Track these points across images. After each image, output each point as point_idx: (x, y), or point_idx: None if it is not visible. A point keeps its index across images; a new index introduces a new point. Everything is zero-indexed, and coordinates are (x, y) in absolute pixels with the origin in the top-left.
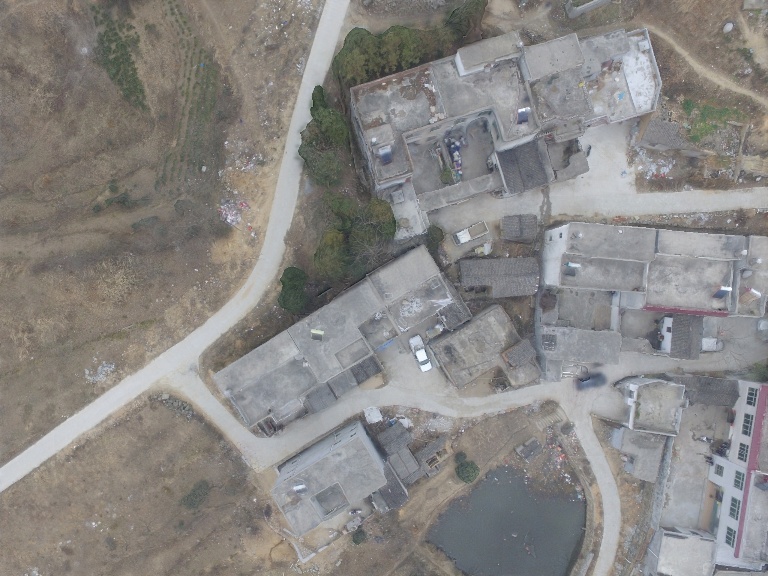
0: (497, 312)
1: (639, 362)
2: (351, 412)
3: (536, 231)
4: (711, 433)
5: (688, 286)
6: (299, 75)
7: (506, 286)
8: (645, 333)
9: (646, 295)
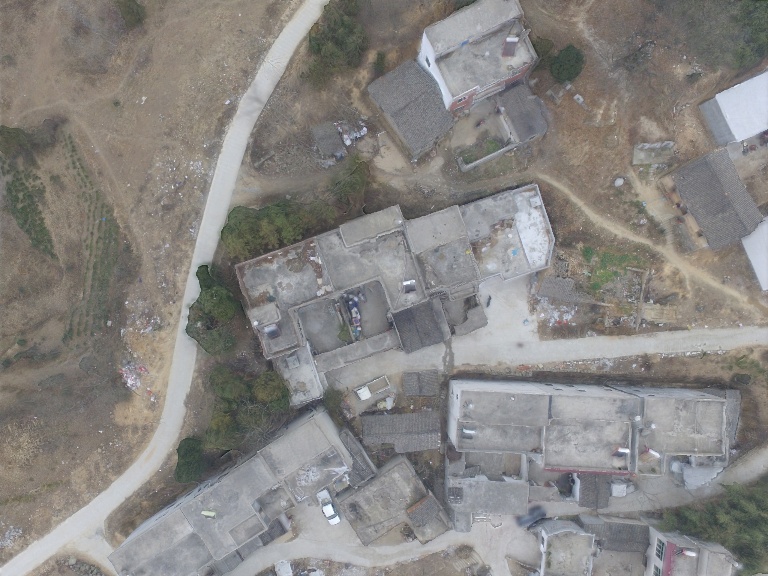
0: (401, 468)
1: (552, 504)
2: (262, 566)
3: (437, 386)
4: (628, 574)
5: (587, 445)
6: (193, 239)
7: (408, 443)
8: (556, 476)
9: (544, 457)
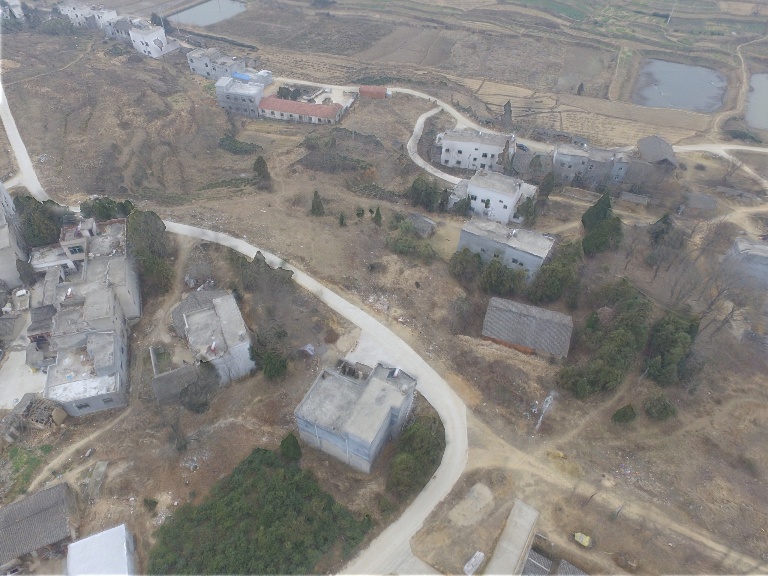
0: None
1: None
2: None
3: None
4: None
5: None
6: (165, 219)
7: None
8: None
9: None
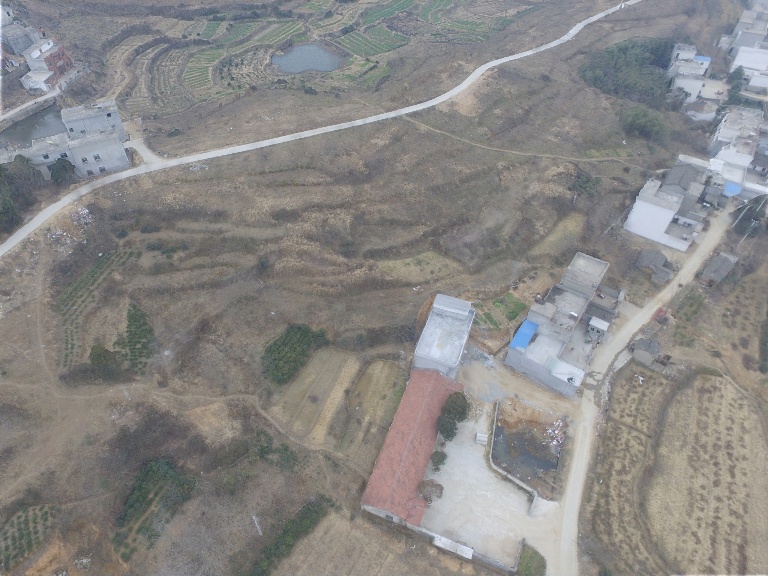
0: None
1: None
2: None
3: None
4: None
5: None
6: None
7: None
8: None
9: None
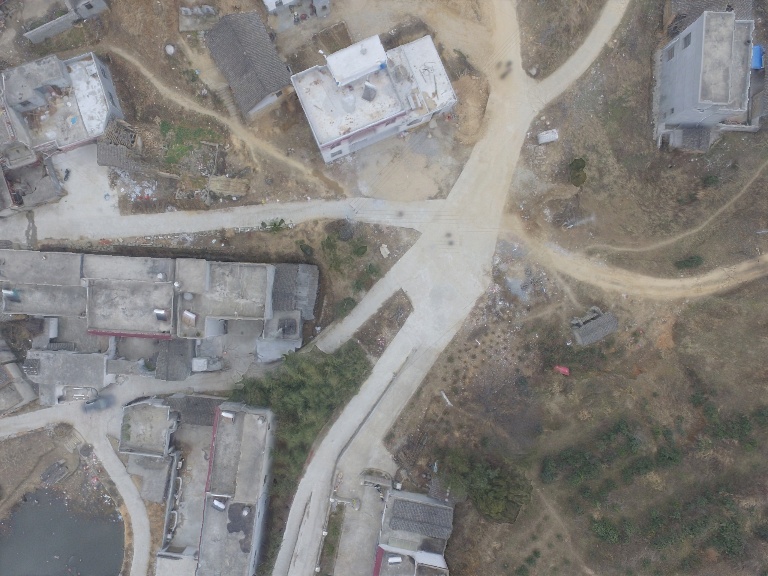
0: None
1: (149, 383)
2: None
3: None
4: None
5: (135, 309)
6: None
7: None
8: (151, 354)
9: (87, 319)
